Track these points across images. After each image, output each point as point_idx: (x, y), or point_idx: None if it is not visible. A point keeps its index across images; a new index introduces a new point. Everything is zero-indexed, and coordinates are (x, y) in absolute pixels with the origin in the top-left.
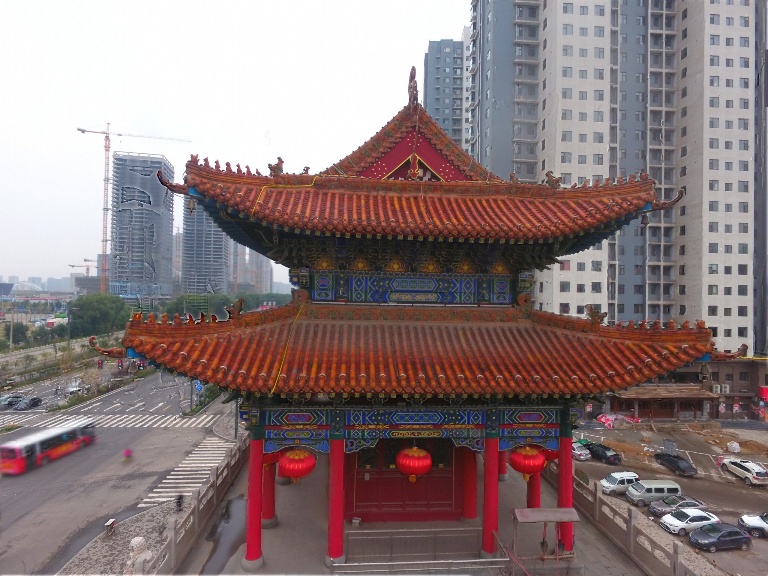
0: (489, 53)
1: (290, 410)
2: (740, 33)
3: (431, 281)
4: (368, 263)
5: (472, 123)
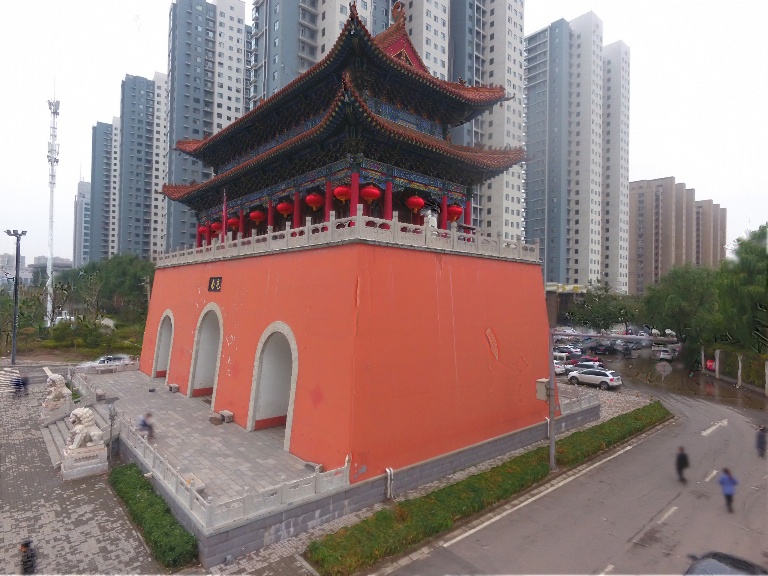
0: (277, 23)
1: (371, 162)
2: (440, 71)
3: (414, 118)
4: (388, 100)
5: (255, 82)
